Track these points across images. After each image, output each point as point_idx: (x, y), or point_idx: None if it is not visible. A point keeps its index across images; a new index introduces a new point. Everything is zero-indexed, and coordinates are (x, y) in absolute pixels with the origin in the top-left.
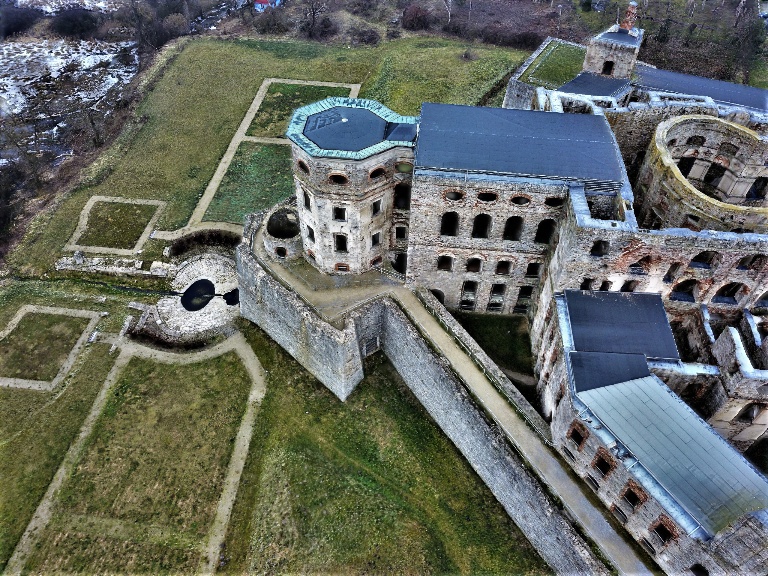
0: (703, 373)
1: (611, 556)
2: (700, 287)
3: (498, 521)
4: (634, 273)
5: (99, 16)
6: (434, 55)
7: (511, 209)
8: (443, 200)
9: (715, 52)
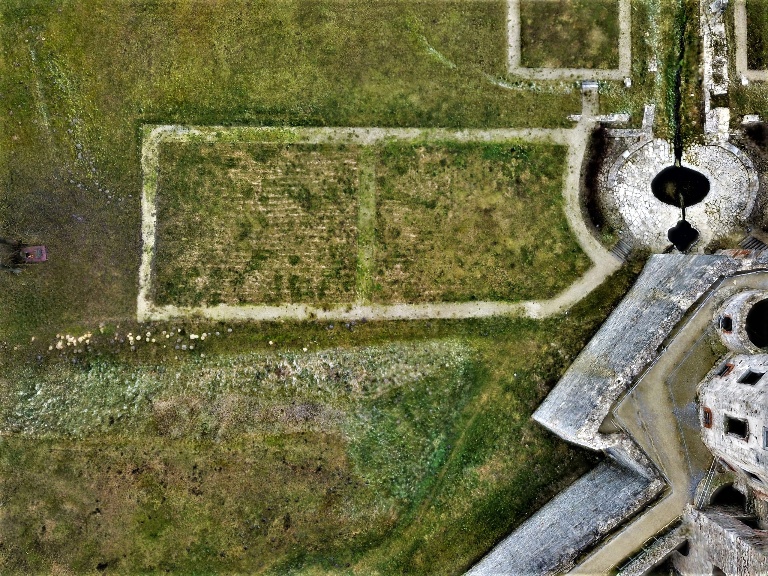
0: None
1: None
2: None
3: None
4: None
5: None
6: None
7: None
8: None
9: None
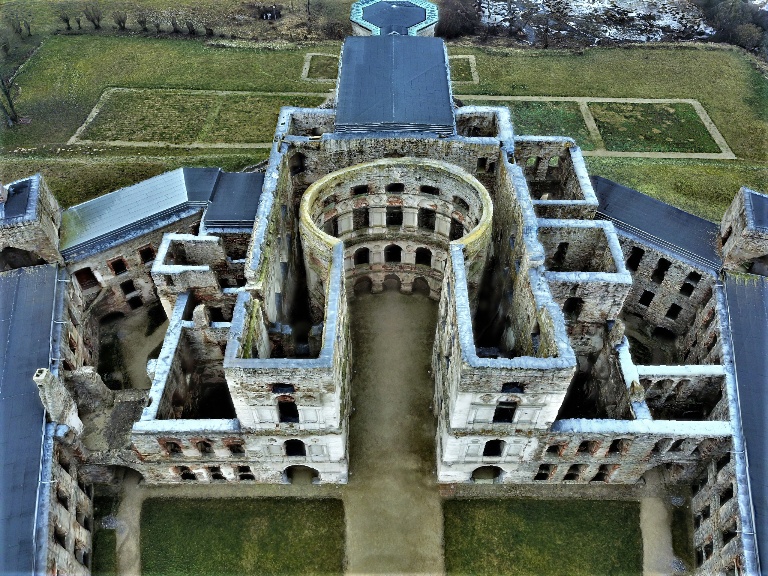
0: None
1: None
2: None
3: None
4: None
5: (728, 2)
6: None
7: None
8: None
9: None
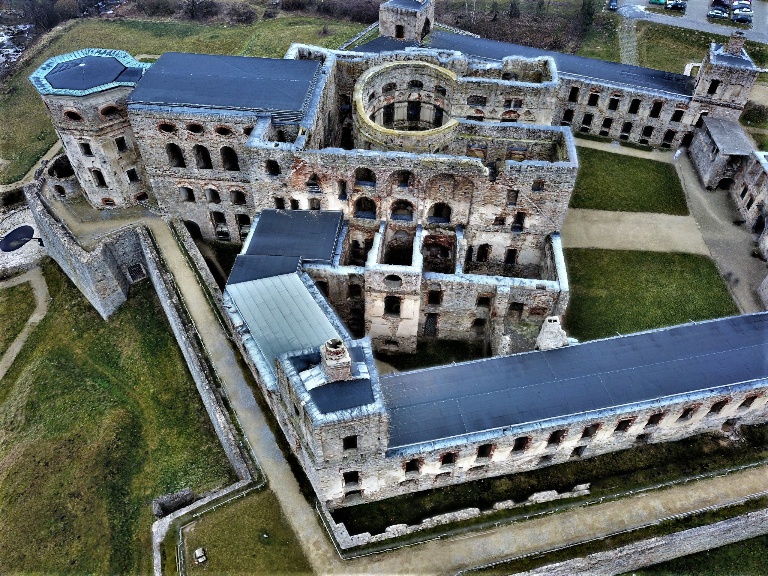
0: (353, 273)
1: (244, 421)
2: (376, 205)
3: (194, 408)
4: (312, 191)
5: None
6: (296, 32)
7: (219, 140)
8: (159, 132)
9: (558, 26)
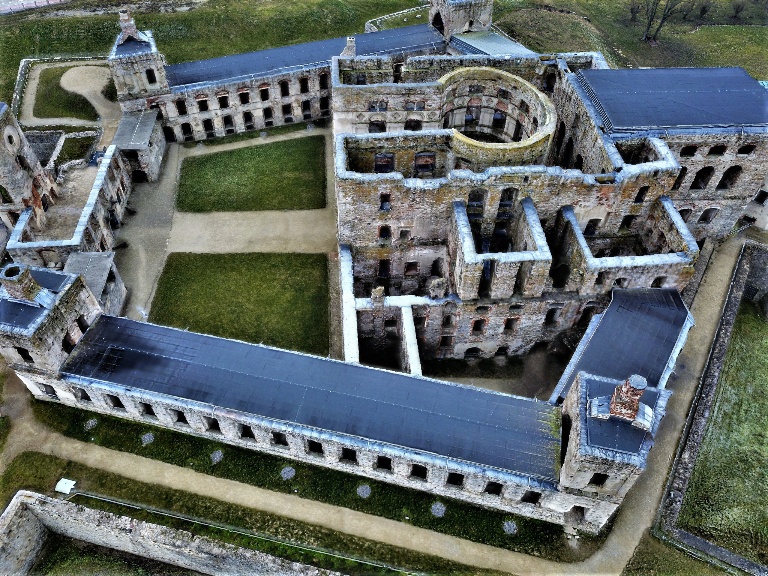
0: None
1: None
2: None
3: None
4: None
5: None
6: None
7: None
8: None
9: None
